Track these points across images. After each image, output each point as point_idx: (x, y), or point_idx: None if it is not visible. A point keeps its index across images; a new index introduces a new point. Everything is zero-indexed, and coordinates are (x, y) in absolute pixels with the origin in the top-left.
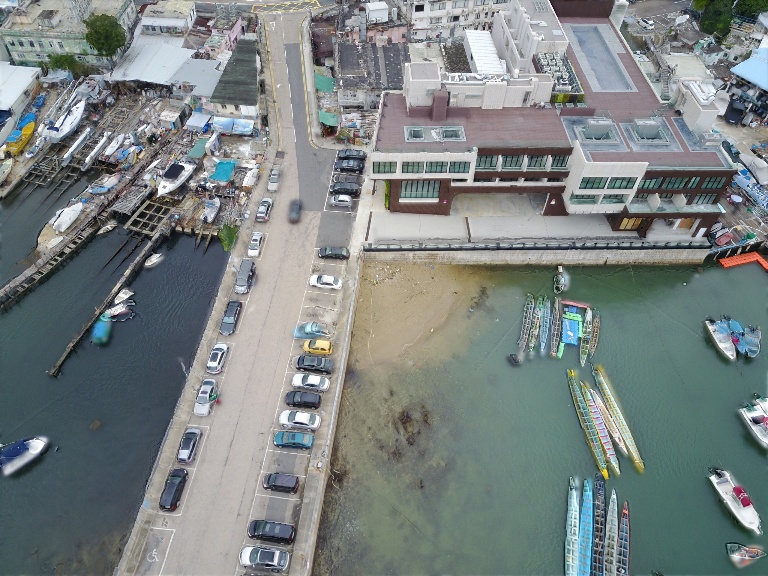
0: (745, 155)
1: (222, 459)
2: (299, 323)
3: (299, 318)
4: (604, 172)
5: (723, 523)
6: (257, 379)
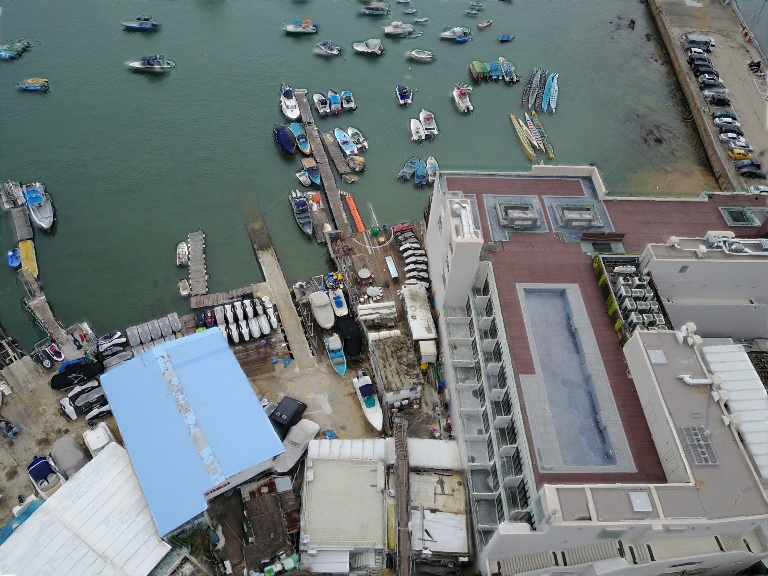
0: (327, 321)
1: (759, 114)
2: (764, 171)
3: (766, 174)
4: (571, 175)
5: (470, 98)
6: (767, 144)
